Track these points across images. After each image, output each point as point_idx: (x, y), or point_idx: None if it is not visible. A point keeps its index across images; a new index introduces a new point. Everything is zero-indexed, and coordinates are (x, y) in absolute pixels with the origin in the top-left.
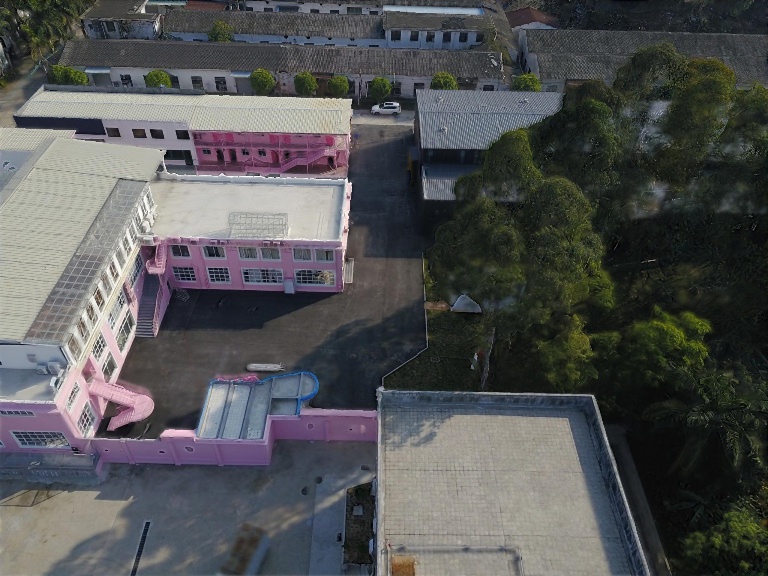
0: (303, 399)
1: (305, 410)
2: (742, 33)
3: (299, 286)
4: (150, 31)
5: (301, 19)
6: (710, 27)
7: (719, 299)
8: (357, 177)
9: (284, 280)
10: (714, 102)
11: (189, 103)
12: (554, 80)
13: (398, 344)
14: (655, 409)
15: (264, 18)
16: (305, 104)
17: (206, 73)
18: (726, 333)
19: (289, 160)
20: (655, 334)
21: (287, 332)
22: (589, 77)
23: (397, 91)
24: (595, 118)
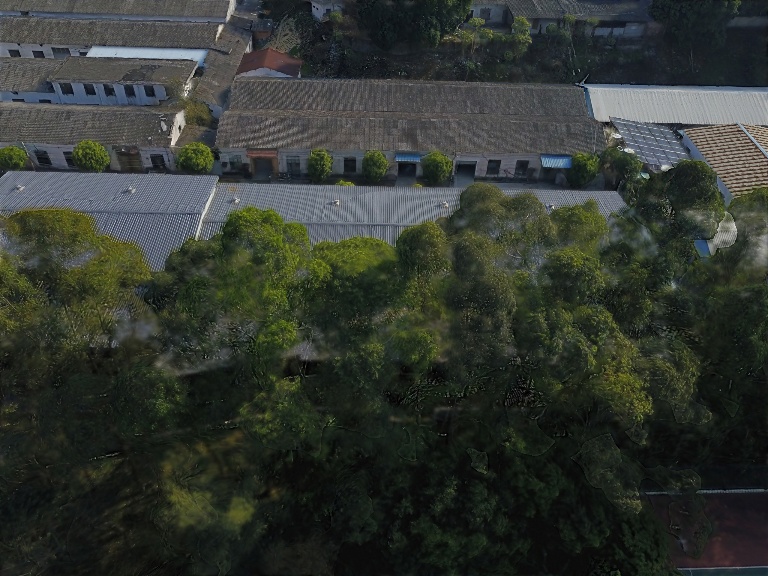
0: None
1: None
2: (522, 79)
3: None
4: None
5: None
6: (484, 72)
7: None
8: None
9: None
10: None
11: None
12: (233, 149)
13: None
14: None
15: None
16: None
17: None
18: None
19: None
20: None
21: None
22: (276, 145)
23: (46, 161)
24: None
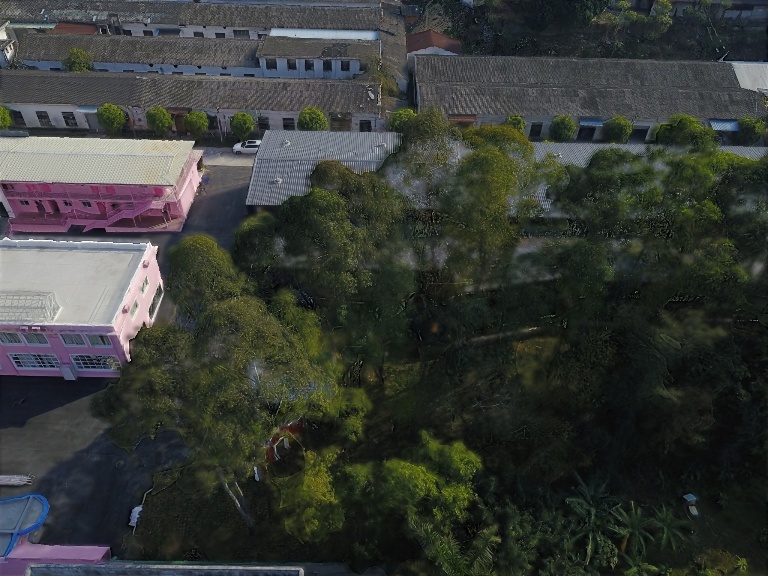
0: (20, 533)
1: (18, 549)
2: (661, 57)
3: (81, 371)
4: (1, 59)
5: (170, 45)
6: (626, 51)
7: (548, 396)
8: (193, 231)
9: (60, 366)
10: (485, 186)
11: (3, 148)
12: None
13: (178, 447)
14: (404, 570)
15: (129, 44)
16: (136, 148)
17: (51, 108)
18: (534, 449)
19: (115, 212)
20: (398, 480)
21: (51, 431)
22: (474, 112)
23: (265, 127)
24: (315, 214)
